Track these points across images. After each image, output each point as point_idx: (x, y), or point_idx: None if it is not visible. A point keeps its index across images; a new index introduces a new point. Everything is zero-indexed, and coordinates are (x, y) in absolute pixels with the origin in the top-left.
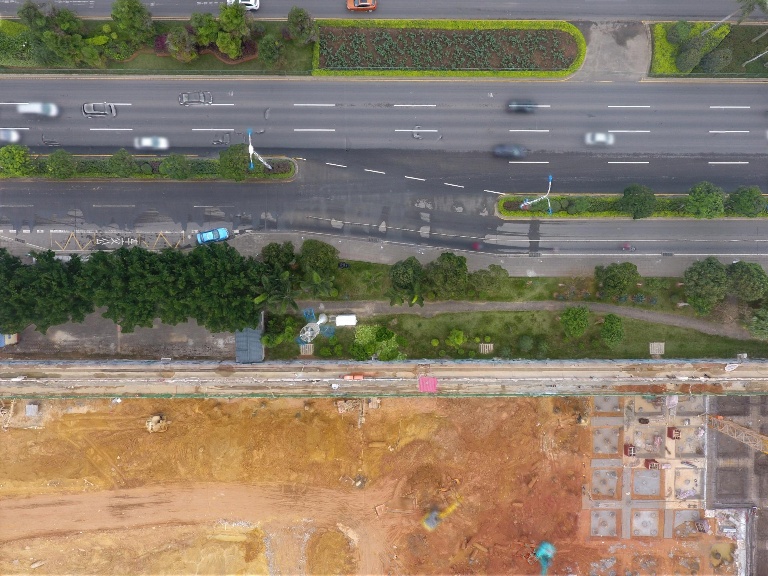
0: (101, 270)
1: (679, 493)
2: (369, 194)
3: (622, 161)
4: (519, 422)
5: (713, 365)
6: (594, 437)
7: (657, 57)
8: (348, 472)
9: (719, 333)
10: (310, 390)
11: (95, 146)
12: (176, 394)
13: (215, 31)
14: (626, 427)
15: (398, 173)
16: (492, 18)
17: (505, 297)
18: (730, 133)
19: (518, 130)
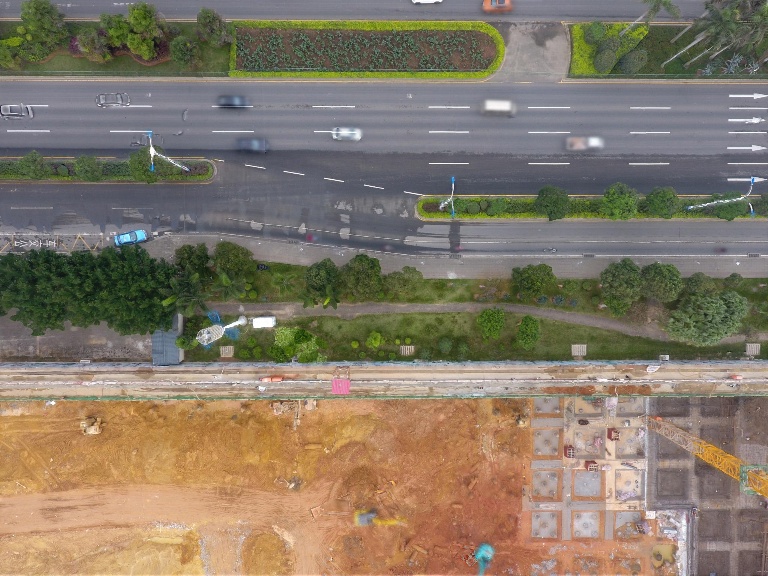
0: (9, 273)
1: (620, 494)
2: (288, 196)
3: (542, 162)
4: (457, 424)
5: (635, 367)
6: (534, 438)
7: (575, 58)
8: (283, 474)
9: (641, 334)
10: (237, 392)
11: (12, 148)
12: (102, 396)
13: (126, 32)
14: (566, 428)
15: (317, 175)
16: (410, 19)
17: (426, 299)
18: (651, 134)
19: (438, 131)
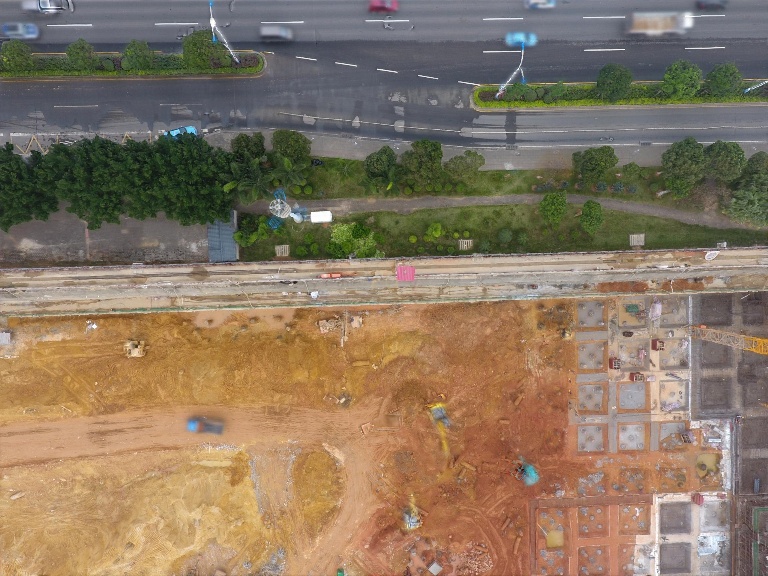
0: (62, 161)
1: (664, 405)
2: (341, 88)
3: (598, 48)
4: (503, 337)
5: (693, 255)
6: (579, 353)
7: None
8: (332, 391)
9: (699, 223)
10: (289, 300)
11: (53, 43)
12: (151, 308)
13: None
14: (610, 341)
15: (370, 66)
16: None
17: (483, 191)
18: (706, 17)
19: (491, 18)
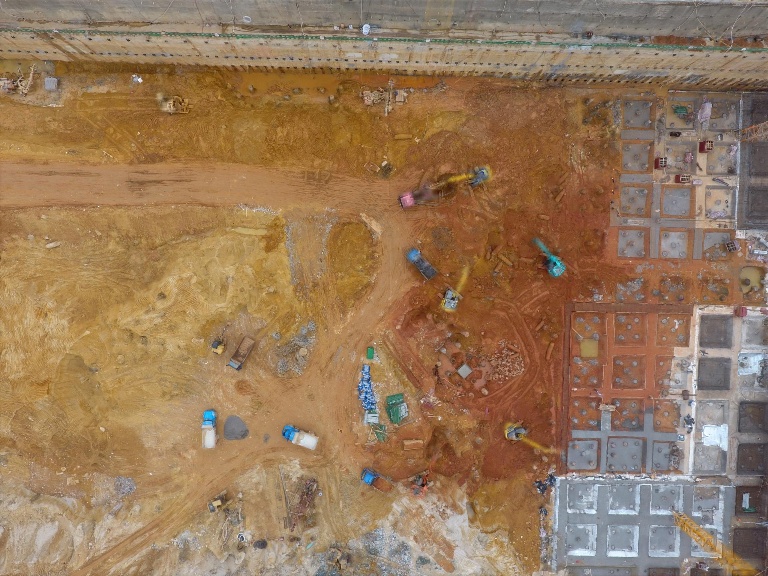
0: None
1: (709, 213)
2: None
3: None
4: (549, 123)
5: None
6: (624, 153)
7: None
8: (373, 160)
9: None
10: (340, 35)
11: None
12: None
13: None
14: (657, 141)
15: None
16: None
17: None
18: None
19: None
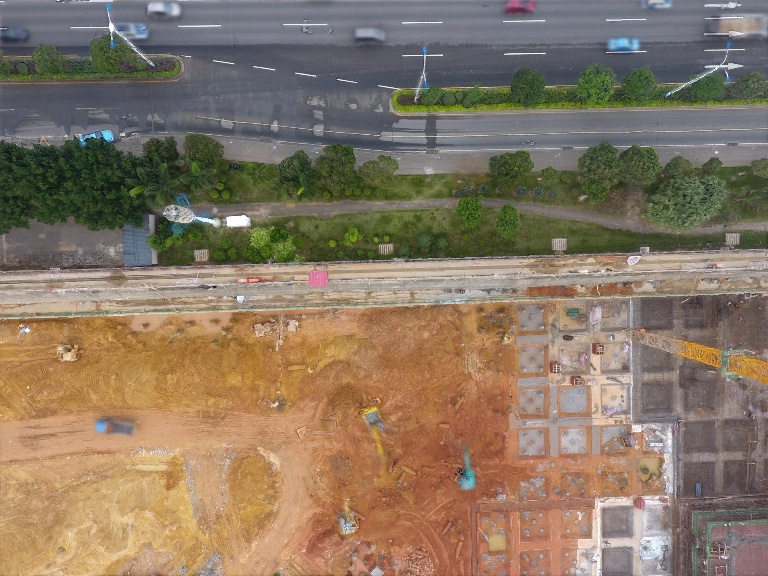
0: None
1: (606, 409)
2: (259, 92)
3: (518, 52)
4: (441, 341)
5: (616, 259)
6: (520, 356)
7: None
8: (267, 395)
9: (621, 227)
10: (215, 304)
11: None
12: (76, 312)
13: None
14: (551, 345)
15: (288, 69)
16: None
17: (403, 196)
18: (627, 21)
19: (410, 22)
